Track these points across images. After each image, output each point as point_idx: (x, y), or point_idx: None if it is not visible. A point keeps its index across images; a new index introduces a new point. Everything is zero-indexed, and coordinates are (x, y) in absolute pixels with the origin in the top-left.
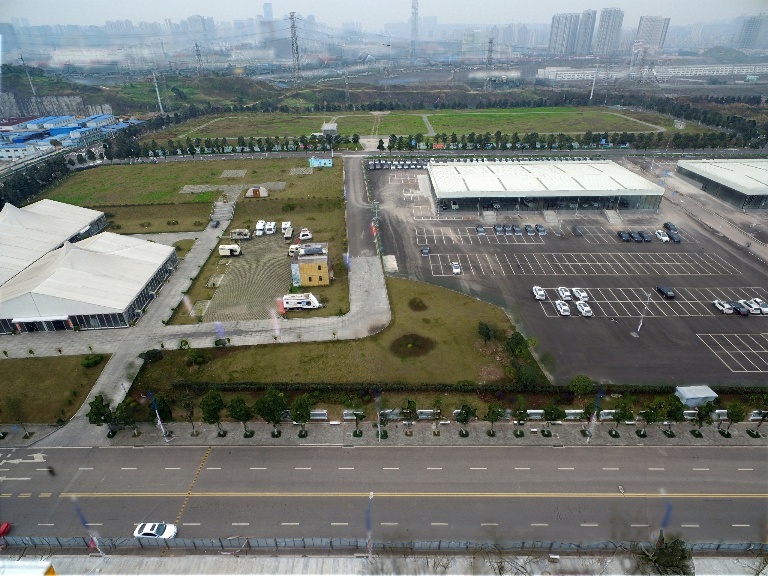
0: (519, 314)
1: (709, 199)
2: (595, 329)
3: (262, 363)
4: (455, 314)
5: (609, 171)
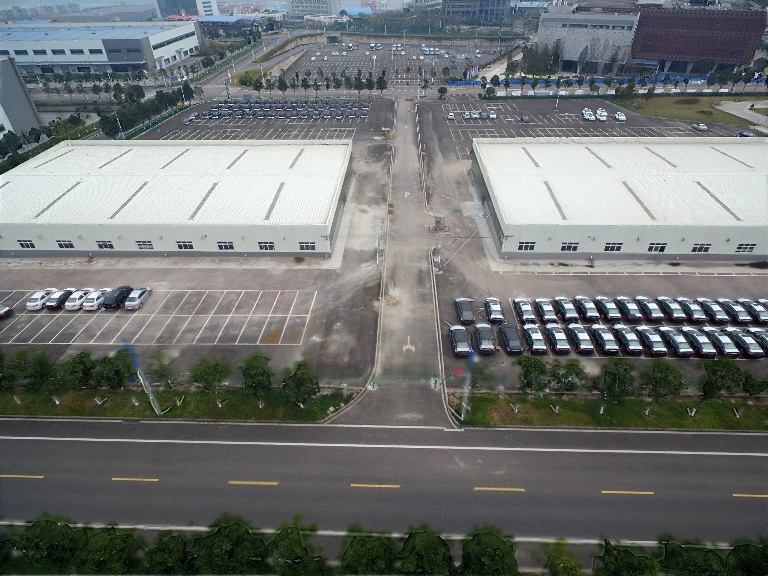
0: (630, 114)
1: (361, 193)
2: (580, 111)
3: (762, 98)
4: (674, 112)
5: (532, 183)
